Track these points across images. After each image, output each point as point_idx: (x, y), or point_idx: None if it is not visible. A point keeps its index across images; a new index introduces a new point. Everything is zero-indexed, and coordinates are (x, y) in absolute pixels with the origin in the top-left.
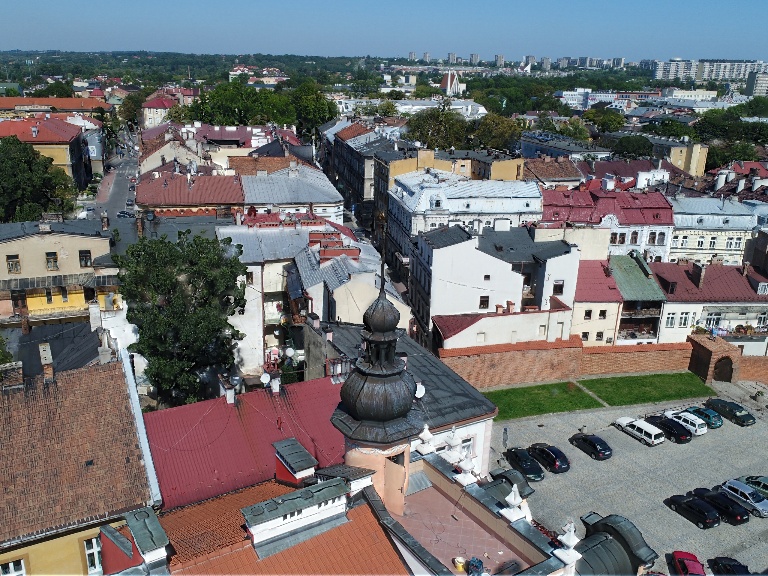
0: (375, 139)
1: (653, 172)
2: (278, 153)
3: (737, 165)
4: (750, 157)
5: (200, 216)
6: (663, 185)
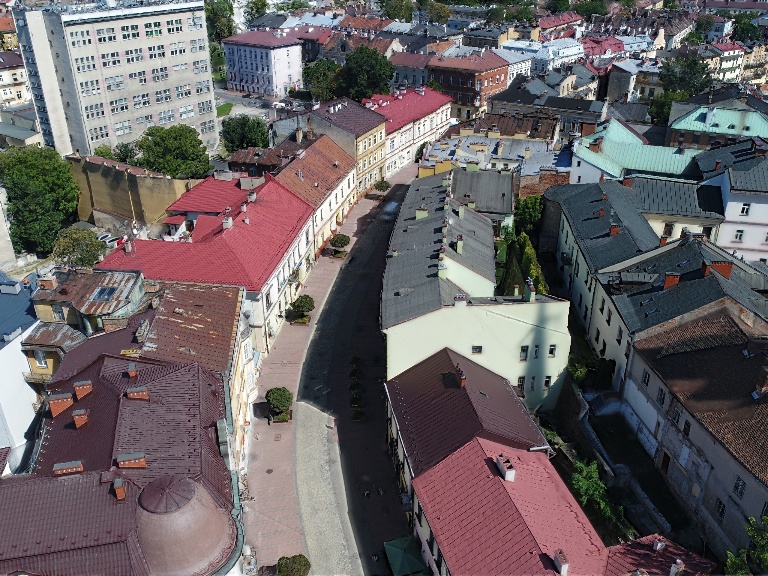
0: (414, 26)
1: (580, 27)
2: (426, 40)
3: (542, 20)
4: (529, 15)
5: (571, 64)
6: (590, 33)
